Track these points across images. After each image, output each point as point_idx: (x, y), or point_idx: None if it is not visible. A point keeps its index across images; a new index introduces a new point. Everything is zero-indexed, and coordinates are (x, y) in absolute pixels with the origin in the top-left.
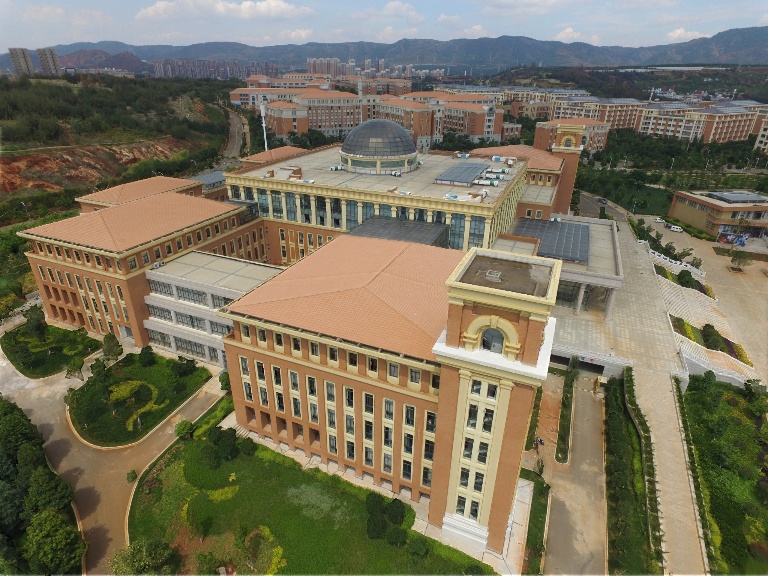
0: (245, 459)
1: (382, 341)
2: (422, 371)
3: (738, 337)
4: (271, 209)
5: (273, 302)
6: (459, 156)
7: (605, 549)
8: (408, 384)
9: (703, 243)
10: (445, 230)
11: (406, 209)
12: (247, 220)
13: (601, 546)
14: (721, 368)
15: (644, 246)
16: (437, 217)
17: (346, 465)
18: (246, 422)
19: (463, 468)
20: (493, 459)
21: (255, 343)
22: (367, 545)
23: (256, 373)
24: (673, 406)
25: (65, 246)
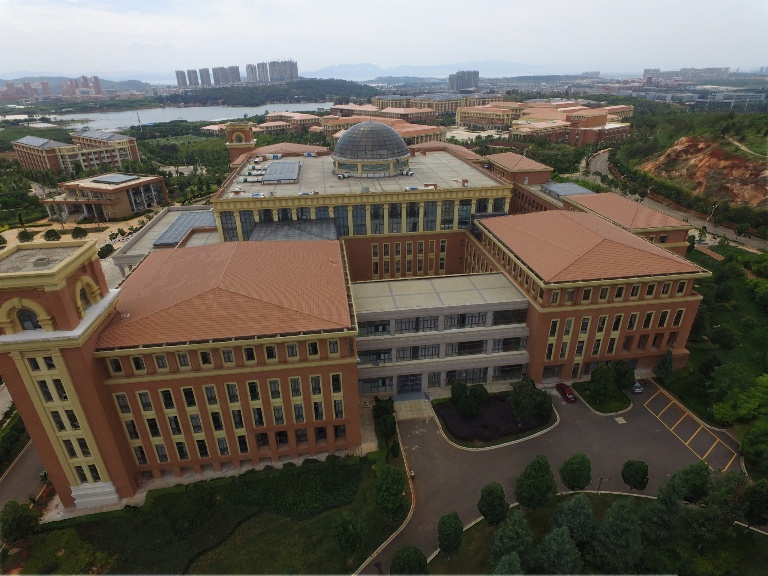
0: None
1: None
2: None
3: None
4: None
5: None
6: None
7: None
8: None
9: None
10: None
11: None
12: None
13: None
14: (119, 243)
15: None
16: None
17: None
18: None
19: None
20: None
21: None
22: None
23: None
24: None
25: None
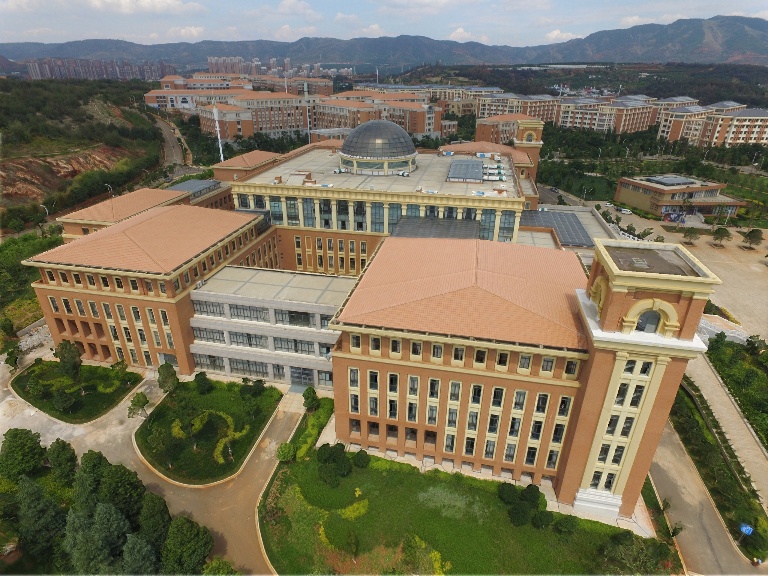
0: (361, 472)
1: (516, 335)
2: (558, 359)
3: (717, 301)
4: (285, 216)
5: (387, 309)
6: (444, 154)
7: (709, 497)
8: (540, 373)
9: (652, 223)
10: (479, 226)
11: (435, 208)
12: (262, 229)
13: (704, 495)
14: None
15: (613, 229)
16: (467, 214)
17: (463, 461)
18: (348, 435)
19: (604, 444)
20: (638, 431)
21: (367, 353)
22: (516, 533)
23: (368, 383)
24: (707, 366)
25: (92, 272)
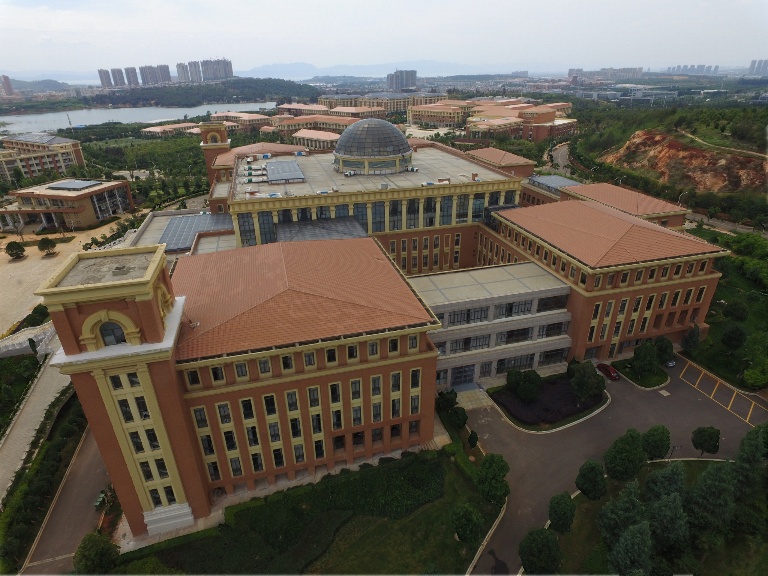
0: None
1: None
2: None
3: None
4: None
5: None
6: None
7: None
8: None
9: None
10: None
11: None
12: None
13: None
14: None
15: None
16: None
17: None
18: None
19: None
20: None
21: None
22: None
23: None
24: None
25: None
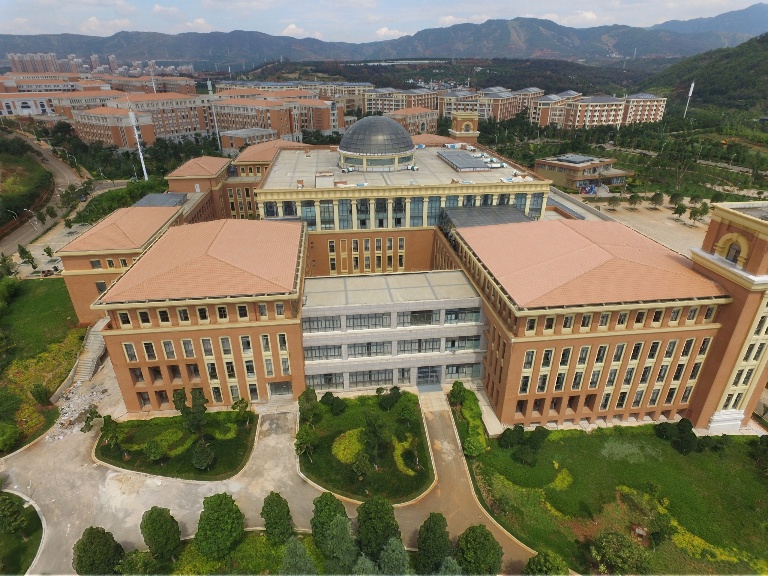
0: (543, 447)
1: (672, 293)
2: (702, 308)
3: None
4: (319, 221)
5: (557, 289)
6: (416, 147)
7: None
8: (686, 323)
9: (574, 196)
10: None
11: (472, 197)
12: None
13: None
14: None
15: None
16: (501, 200)
17: (615, 415)
18: (513, 417)
19: (739, 370)
20: (767, 353)
21: (541, 333)
22: (690, 461)
23: (542, 362)
24: None
25: (193, 304)
